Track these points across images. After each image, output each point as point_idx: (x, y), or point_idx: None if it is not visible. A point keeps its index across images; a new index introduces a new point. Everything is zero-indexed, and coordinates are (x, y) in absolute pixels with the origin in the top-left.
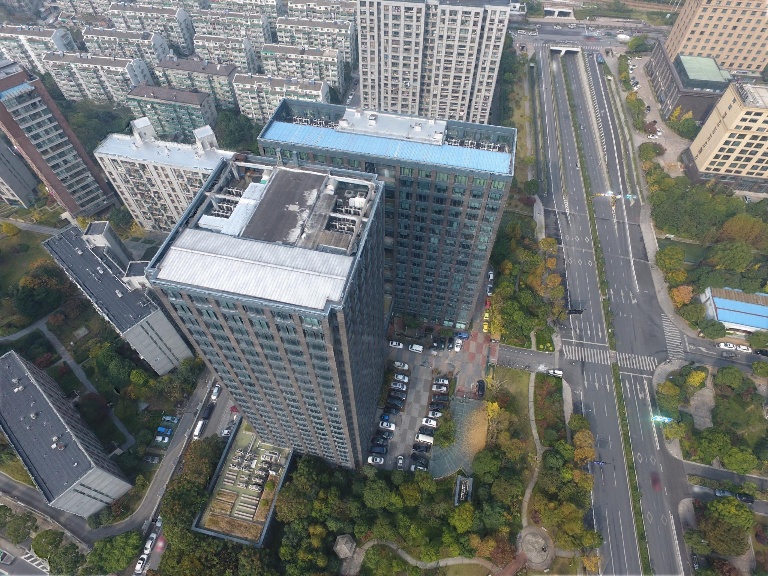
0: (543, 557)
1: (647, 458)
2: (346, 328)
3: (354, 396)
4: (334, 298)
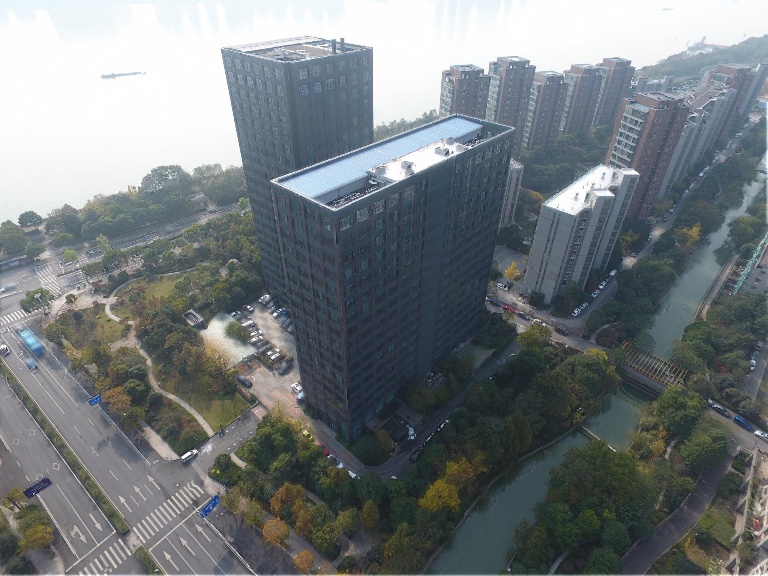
0: (116, 348)
1: (47, 472)
2: (226, 74)
3: (243, 163)
4: (228, 47)
